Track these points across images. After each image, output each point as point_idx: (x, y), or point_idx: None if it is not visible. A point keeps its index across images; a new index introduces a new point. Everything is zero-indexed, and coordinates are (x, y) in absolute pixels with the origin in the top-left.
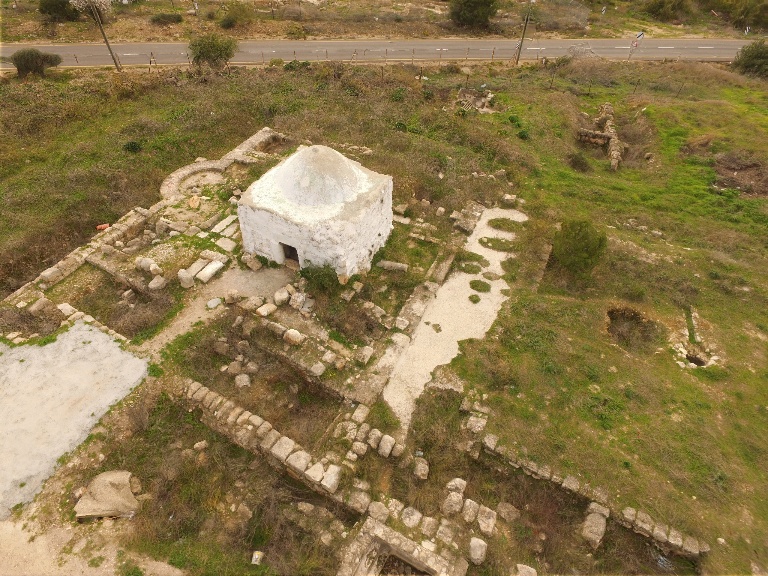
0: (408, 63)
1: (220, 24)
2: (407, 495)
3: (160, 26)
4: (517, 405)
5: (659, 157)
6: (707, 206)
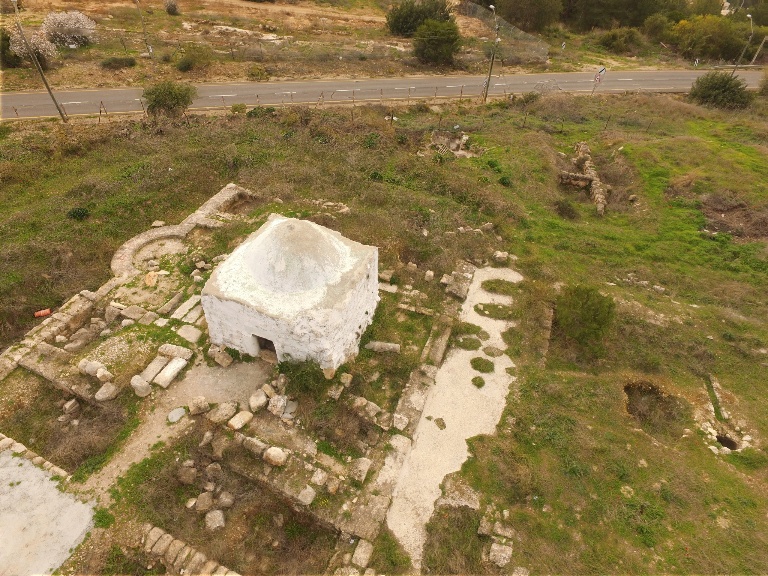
0: (376, 103)
1: (177, 67)
2: None
3: (111, 71)
4: (544, 522)
5: (645, 200)
6: (703, 254)
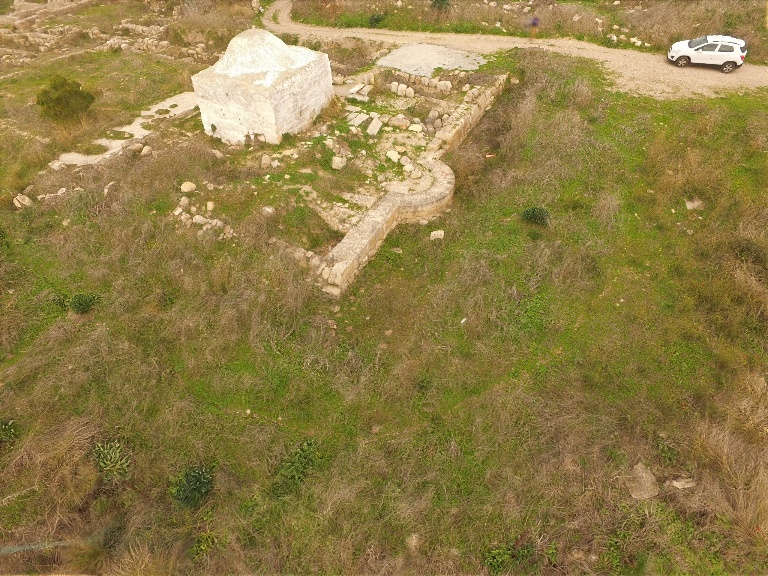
0: None
1: None
2: None
3: None
4: None
5: None
6: None
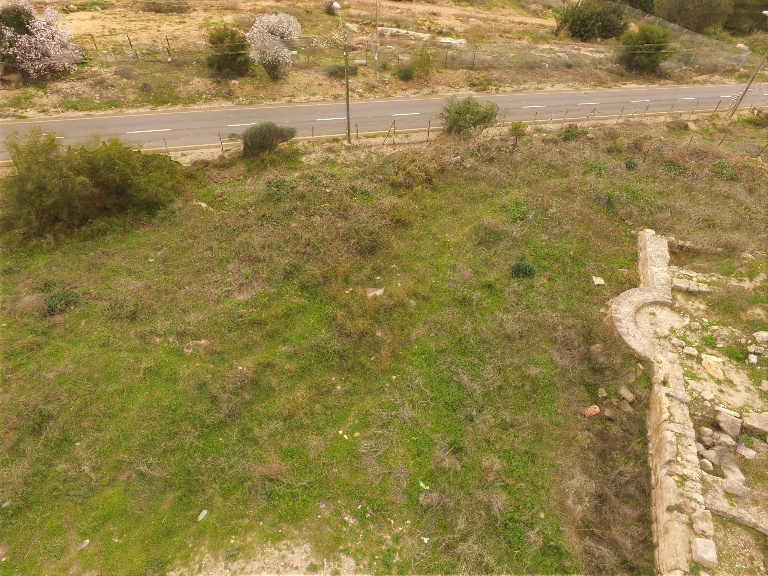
0: (634, 120)
1: (397, 76)
2: None
3: (337, 80)
4: None
5: None
6: None
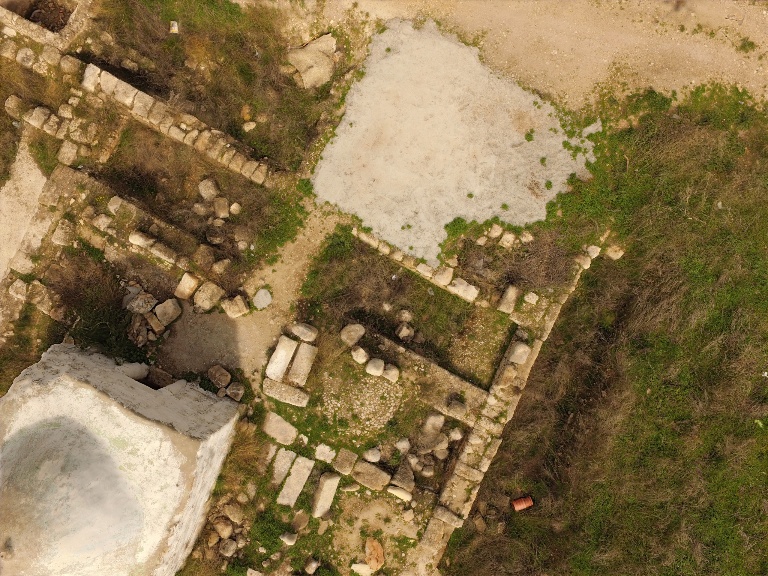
0: None
1: None
2: (30, 78)
3: None
4: None
5: None
6: None
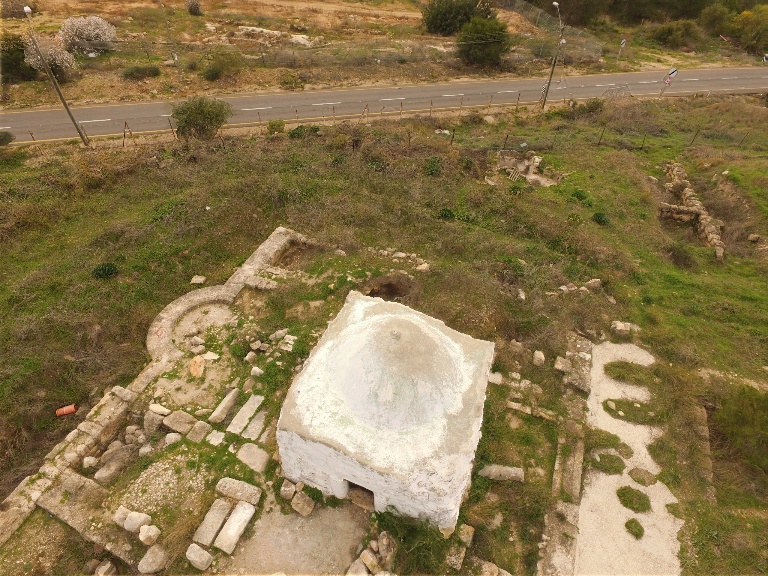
0: (425, 115)
1: (204, 76)
2: None
3: (134, 81)
4: None
5: None
6: None
